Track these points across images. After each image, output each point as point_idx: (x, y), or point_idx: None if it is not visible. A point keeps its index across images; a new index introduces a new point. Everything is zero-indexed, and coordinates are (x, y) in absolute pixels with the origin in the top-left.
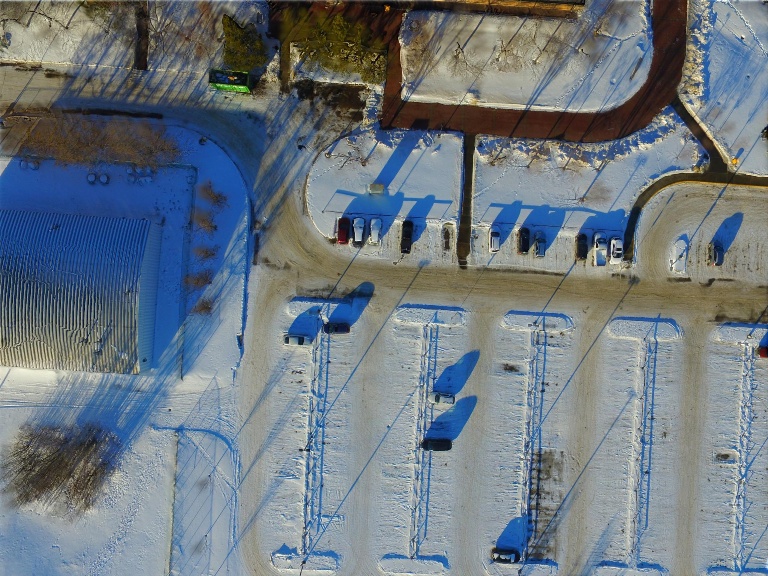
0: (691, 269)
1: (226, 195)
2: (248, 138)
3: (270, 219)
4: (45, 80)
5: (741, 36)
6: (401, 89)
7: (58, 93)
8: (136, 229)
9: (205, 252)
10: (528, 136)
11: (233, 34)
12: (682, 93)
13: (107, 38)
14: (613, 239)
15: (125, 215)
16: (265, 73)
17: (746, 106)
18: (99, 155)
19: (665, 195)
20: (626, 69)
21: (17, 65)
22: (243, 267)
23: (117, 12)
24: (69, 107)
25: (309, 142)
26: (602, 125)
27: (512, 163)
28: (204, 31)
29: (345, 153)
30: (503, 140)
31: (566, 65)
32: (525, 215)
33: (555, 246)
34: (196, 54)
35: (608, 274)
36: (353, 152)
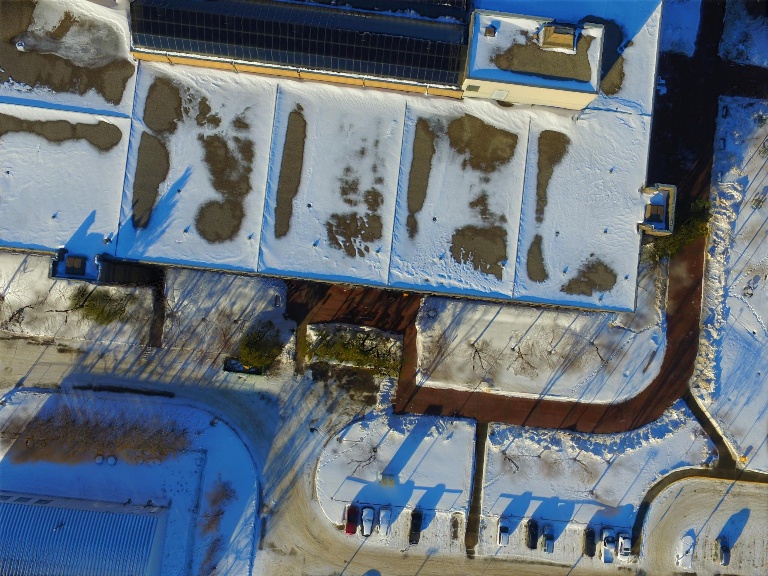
0: (697, 564)
1: (235, 485)
2: (260, 419)
3: (278, 503)
4: (57, 355)
5: (753, 331)
6: (416, 374)
7: (70, 368)
8: (142, 528)
9: (211, 537)
10: (540, 425)
11: (252, 356)
12: (694, 387)
13: (123, 316)
14: (621, 537)
15: (131, 497)
16: (280, 354)
17: (756, 404)
18: (108, 436)
19: (674, 490)
20: (639, 362)
21: (29, 338)
22: (249, 553)
23: (134, 292)
24: (80, 383)
25: (321, 425)
26: (614, 417)
27: (523, 453)
28: (221, 313)
29: (357, 438)
30: (515, 429)
31: (581, 357)
32: (534, 507)
33: (563, 538)
34: (212, 334)
35: (615, 567)
36: (365, 437)
